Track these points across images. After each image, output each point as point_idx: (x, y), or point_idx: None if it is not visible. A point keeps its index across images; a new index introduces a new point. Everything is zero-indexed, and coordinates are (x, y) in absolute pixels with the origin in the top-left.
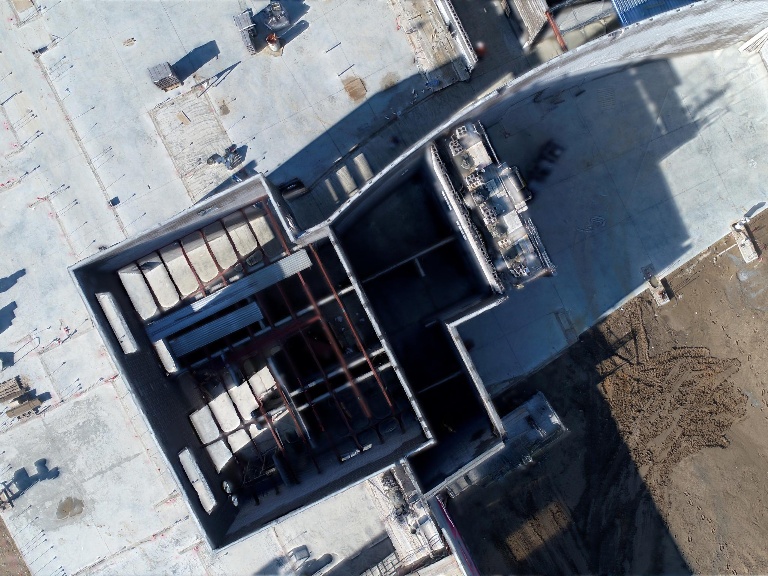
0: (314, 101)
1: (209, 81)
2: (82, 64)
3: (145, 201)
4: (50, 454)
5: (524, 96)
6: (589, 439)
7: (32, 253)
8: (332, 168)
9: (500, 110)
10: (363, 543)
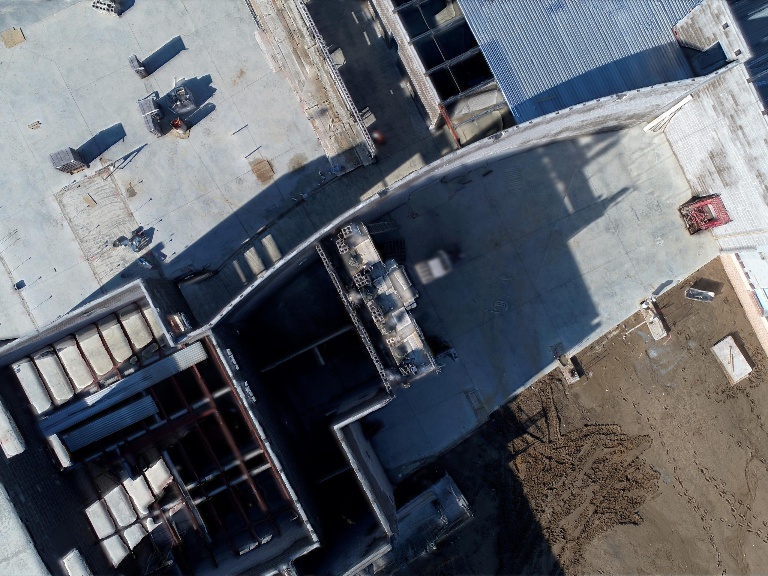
0: (221, 183)
1: (115, 164)
2: None
3: (51, 284)
4: None
5: (422, 185)
6: (502, 518)
7: None
8: (240, 249)
9: (399, 198)
10: None
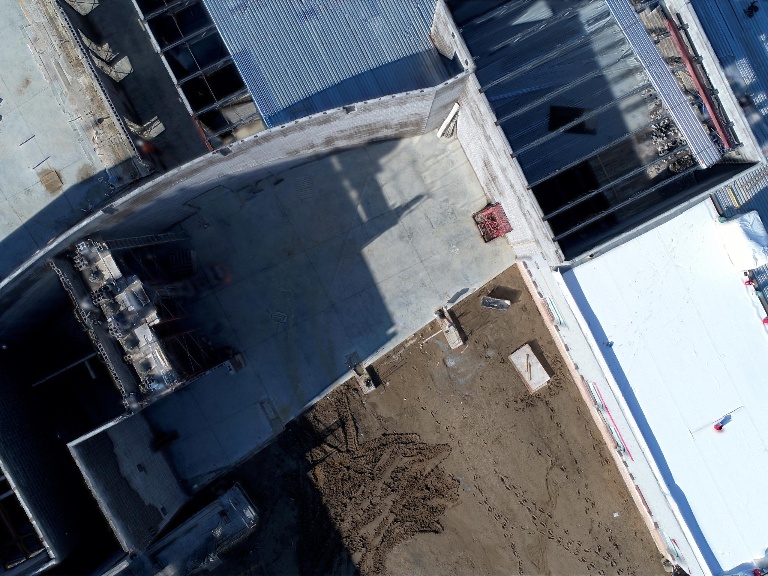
0: (10, 194)
1: None
2: None
3: None
4: None
5: (188, 197)
6: (301, 527)
7: None
8: None
9: (167, 210)
10: None
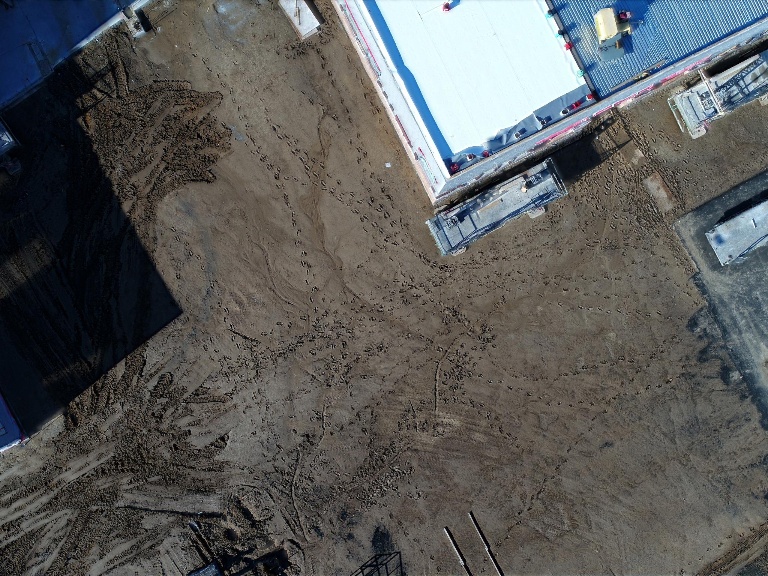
0: None
1: None
2: None
3: None
4: None
5: None
6: (71, 174)
7: None
8: None
9: None
10: None
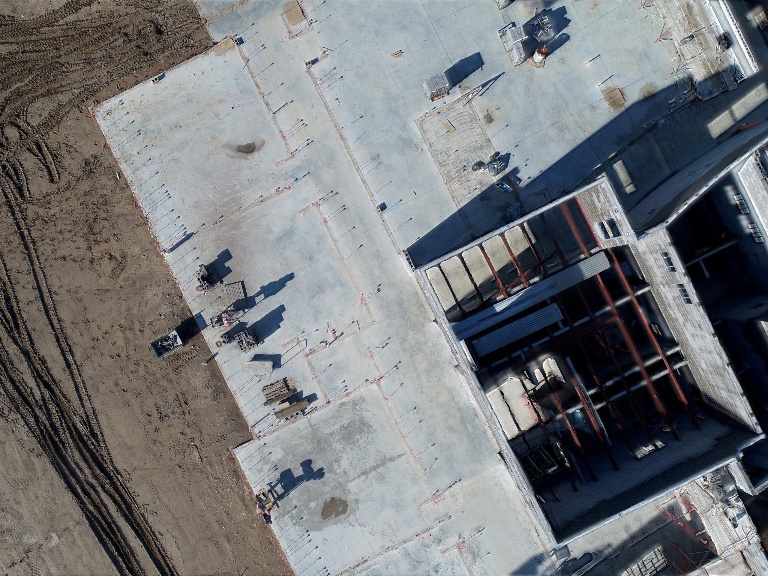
0: (574, 110)
1: None
2: (351, 75)
3: (411, 207)
4: (316, 455)
5: None
6: None
7: (301, 257)
8: (592, 174)
9: None
10: (623, 542)
